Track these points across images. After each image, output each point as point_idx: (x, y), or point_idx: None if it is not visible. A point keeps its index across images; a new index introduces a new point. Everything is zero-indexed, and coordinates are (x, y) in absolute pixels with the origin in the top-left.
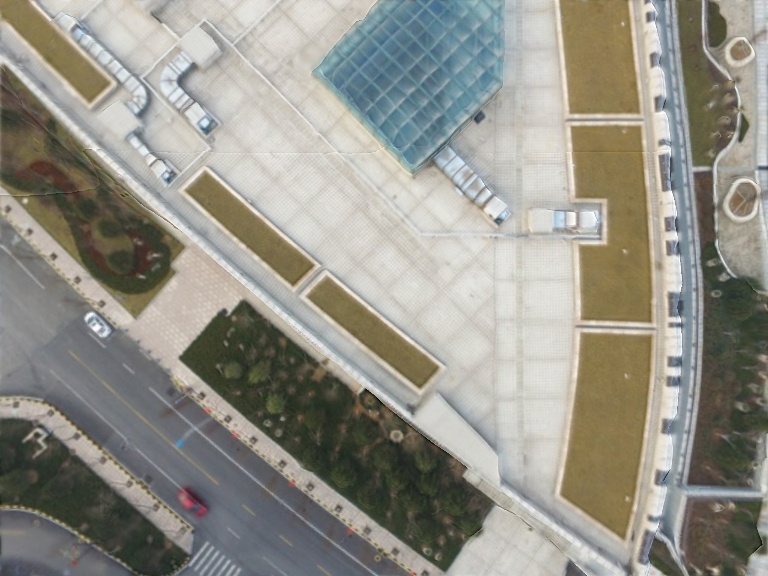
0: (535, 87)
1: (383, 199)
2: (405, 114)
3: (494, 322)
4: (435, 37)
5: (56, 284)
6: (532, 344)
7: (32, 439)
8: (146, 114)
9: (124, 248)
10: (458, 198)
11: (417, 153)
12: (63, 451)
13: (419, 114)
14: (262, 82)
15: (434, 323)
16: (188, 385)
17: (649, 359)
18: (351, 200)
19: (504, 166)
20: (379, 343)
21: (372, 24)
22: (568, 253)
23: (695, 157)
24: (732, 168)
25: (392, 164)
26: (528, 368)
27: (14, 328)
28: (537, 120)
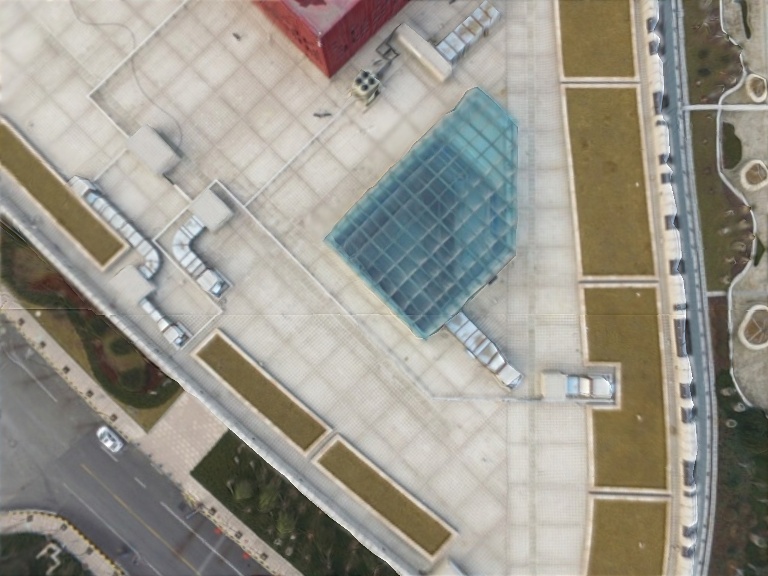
0: (548, 246)
1: (395, 361)
2: (417, 285)
3: (506, 486)
4: (447, 206)
5: (69, 399)
6: (545, 509)
7: (46, 555)
8: (158, 277)
9: (136, 365)
10: (470, 360)
11: (429, 321)
12: (76, 566)
13: (431, 285)
14: (273, 243)
15: (446, 487)
16: (199, 500)
17: (664, 527)
18: (362, 362)
19: (516, 327)
20: (391, 509)
21: (384, 192)
22: (581, 417)
23: (709, 282)
24: (747, 292)
25: (404, 328)
26: (541, 533)
27: (28, 441)
28: (550, 280)
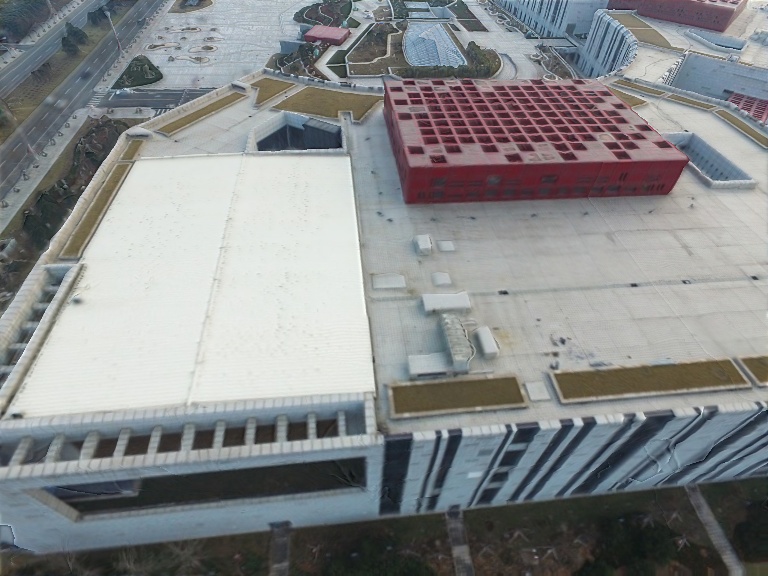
0: None
1: None
2: None
3: None
4: None
5: None
6: None
7: None
8: None
9: None
10: None
11: None
12: None
13: None
14: None
15: None
16: None
17: None
18: None
19: None
20: None
21: None
22: None
23: None
24: (486, 6)
25: None
26: None
27: None
28: None
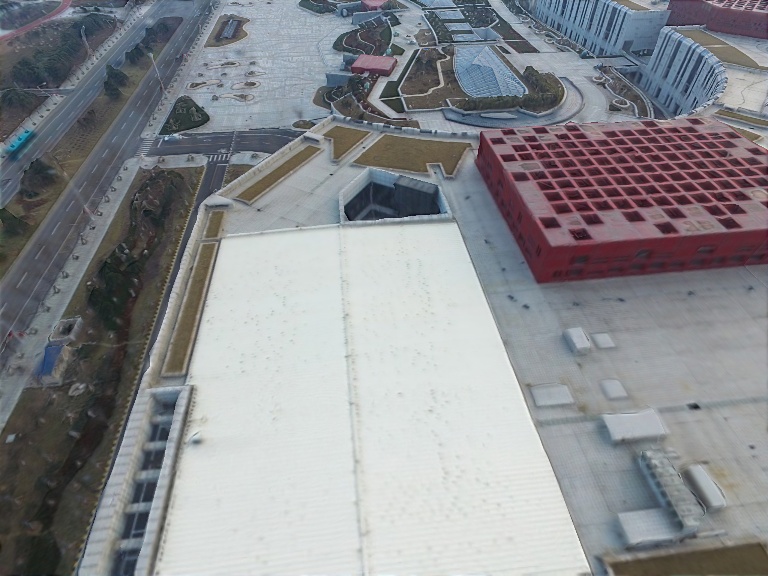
0: None
1: None
2: None
3: None
4: None
5: None
6: None
7: None
8: None
9: None
10: None
11: None
12: None
13: None
14: None
15: None
16: None
17: None
18: None
19: None
20: None
21: None
22: None
23: None
24: None
25: None
26: None
27: None
28: None
